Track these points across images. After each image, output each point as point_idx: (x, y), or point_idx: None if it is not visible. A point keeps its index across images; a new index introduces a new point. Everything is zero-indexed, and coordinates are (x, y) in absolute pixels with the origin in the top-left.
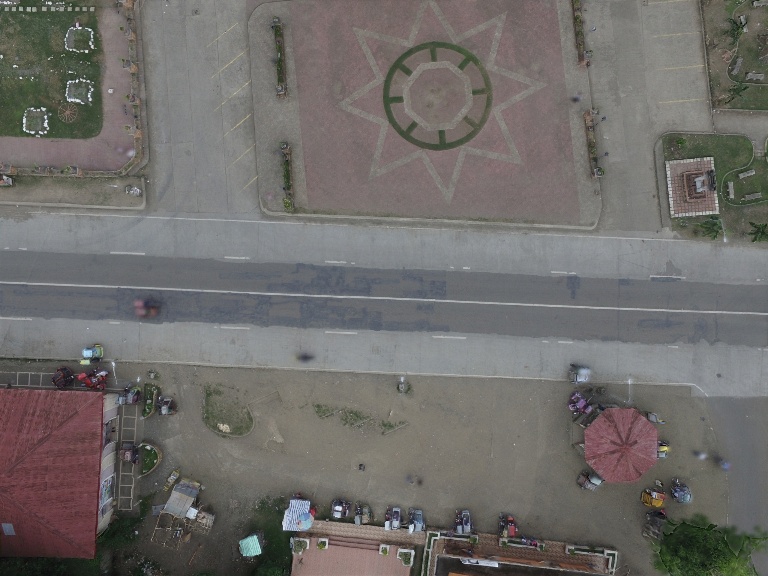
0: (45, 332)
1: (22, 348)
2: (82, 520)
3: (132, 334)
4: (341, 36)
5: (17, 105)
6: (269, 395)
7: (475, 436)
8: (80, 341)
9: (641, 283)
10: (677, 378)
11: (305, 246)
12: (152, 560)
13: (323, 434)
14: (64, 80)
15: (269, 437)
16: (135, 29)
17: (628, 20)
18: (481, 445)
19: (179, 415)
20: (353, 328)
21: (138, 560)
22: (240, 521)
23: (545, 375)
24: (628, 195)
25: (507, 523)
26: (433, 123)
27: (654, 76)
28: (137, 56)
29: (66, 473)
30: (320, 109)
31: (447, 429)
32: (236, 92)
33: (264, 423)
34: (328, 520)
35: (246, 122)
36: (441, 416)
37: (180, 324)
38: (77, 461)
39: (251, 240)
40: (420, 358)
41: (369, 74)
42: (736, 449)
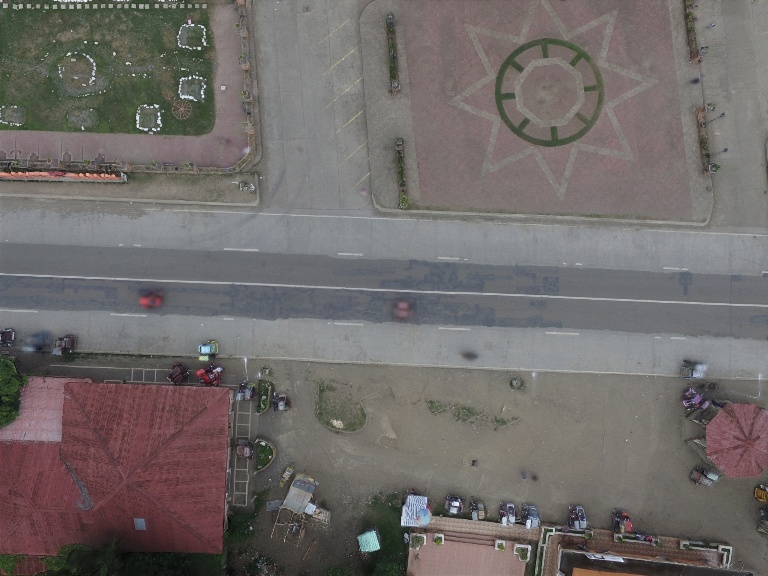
0: (159, 328)
1: (137, 344)
2: (211, 515)
3: (246, 330)
4: (453, 33)
5: (130, 102)
6: (382, 391)
7: (587, 432)
8: (194, 337)
9: (753, 279)
10: None
11: (418, 242)
12: (266, 556)
13: (436, 430)
14: (177, 77)
15: (382, 433)
16: (247, 26)
17: (739, 16)
18: (593, 441)
19: (292, 411)
20: (466, 324)
21: (252, 556)
22: (353, 517)
23: (657, 371)
24: (740, 191)
25: (623, 519)
26: (545, 119)
27: (765, 72)
28: (249, 53)
29: (196, 468)
30: (432, 106)
31: (559, 425)
32: (348, 89)
33: (377, 419)
34: (442, 516)
35: (358, 119)
36: (553, 412)
37: (294, 320)
38: (206, 456)
39: (364, 236)
40: (533, 354)
41: (481, 71)
42: None
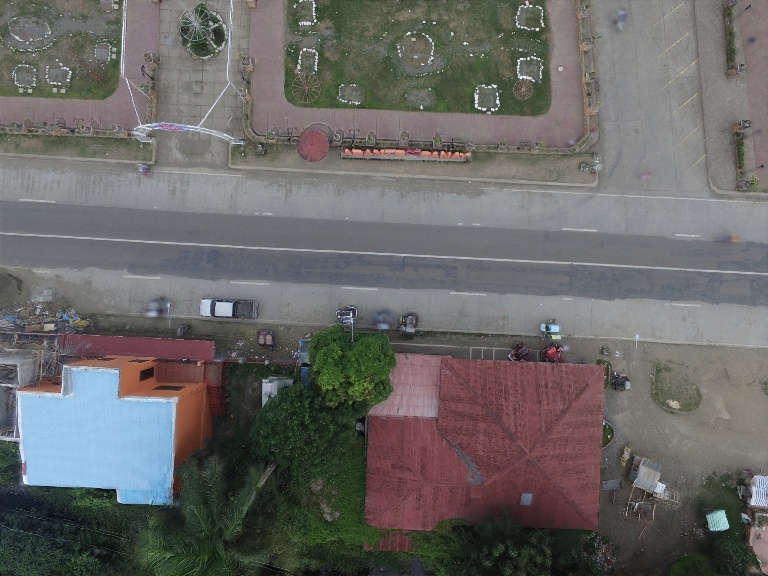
0: (499, 307)
1: (477, 323)
2: (590, 491)
3: (585, 310)
4: None
5: (467, 82)
6: (717, 372)
7: None
8: (533, 316)
9: None
10: None
11: (754, 224)
12: (602, 535)
13: None
14: (514, 57)
15: (716, 414)
16: None
17: None
18: None
19: (628, 391)
20: None
21: (588, 535)
22: (688, 497)
23: None
24: None
25: None
26: None
27: None
28: (587, 34)
29: (580, 444)
30: (767, 89)
31: None
32: (683, 71)
33: (711, 400)
34: None
35: (694, 101)
36: None
37: (632, 301)
38: (588, 433)
39: (701, 218)
40: None
41: None
42: None
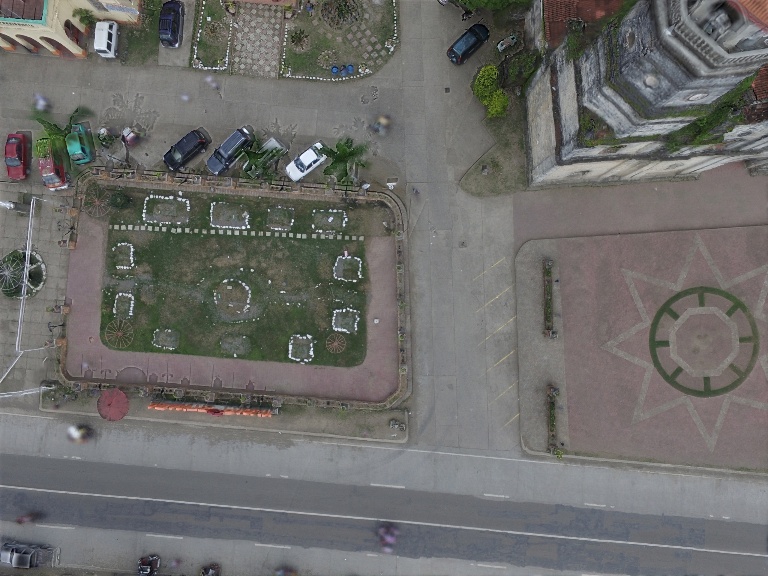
0: (303, 561)
1: (280, 575)
2: None
3: (389, 567)
4: (609, 277)
5: (283, 331)
6: None
7: None
8: (337, 572)
9: None
10: None
11: (565, 487)
12: None
13: None
14: (330, 308)
15: None
16: (403, 260)
17: None
18: None
19: None
20: (610, 572)
21: None
22: None
23: None
24: None
25: None
26: (698, 369)
27: None
28: (404, 288)
29: None
30: (585, 349)
31: None
32: (500, 327)
33: None
34: None
35: (510, 358)
36: None
37: (437, 559)
38: None
39: (511, 478)
40: None
41: (636, 317)
42: None
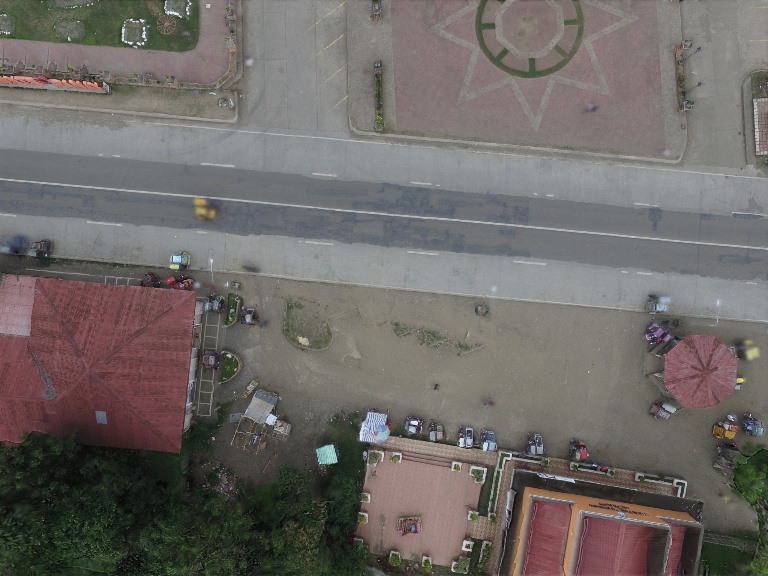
0: (134, 238)
1: (111, 252)
2: (171, 414)
3: (218, 244)
4: None
5: (116, 16)
6: (349, 311)
7: (550, 362)
8: (168, 248)
9: (723, 219)
10: (754, 315)
11: (391, 166)
12: (227, 466)
13: (400, 352)
14: None
15: (347, 352)
16: None
17: None
18: (555, 371)
19: (260, 326)
20: (435, 249)
21: (213, 466)
22: (315, 433)
23: (622, 305)
24: (714, 131)
25: (579, 447)
26: (523, 51)
27: (746, 14)
28: None
29: (159, 366)
30: (412, 32)
31: (522, 354)
32: (330, 12)
33: (342, 338)
34: (401, 436)
35: (339, 42)
36: (517, 340)
37: (266, 237)
38: (169, 356)
39: (339, 158)
40: (499, 282)
41: None
42: None
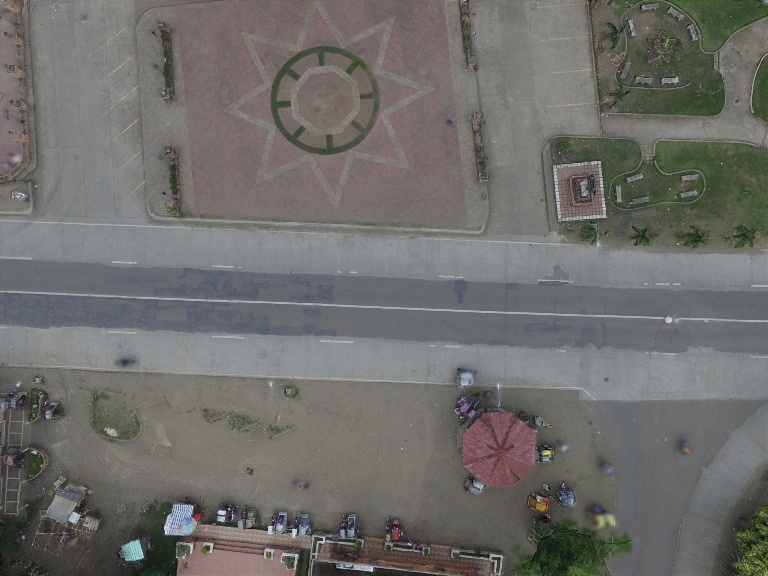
0: None
1: None
2: None
3: (19, 339)
4: (229, 41)
5: None
6: (157, 399)
7: (363, 440)
8: None
9: (528, 287)
10: (564, 382)
11: (192, 251)
12: (39, 564)
13: (211, 438)
14: None
15: (157, 441)
16: (23, 34)
17: (516, 24)
18: (369, 449)
19: (67, 420)
20: (240, 332)
21: (25, 564)
22: (127, 525)
23: (432, 379)
24: (516, 199)
25: (391, 527)
26: (320, 127)
27: (542, 80)
28: (25, 61)
29: None
30: (208, 114)
31: (335, 433)
32: (124, 97)
33: (152, 427)
34: (215, 524)
35: (134, 127)
36: (329, 420)
37: (67, 329)
38: None
39: (138, 245)
40: (307, 362)
41: (257, 79)
42: (623, 453)
